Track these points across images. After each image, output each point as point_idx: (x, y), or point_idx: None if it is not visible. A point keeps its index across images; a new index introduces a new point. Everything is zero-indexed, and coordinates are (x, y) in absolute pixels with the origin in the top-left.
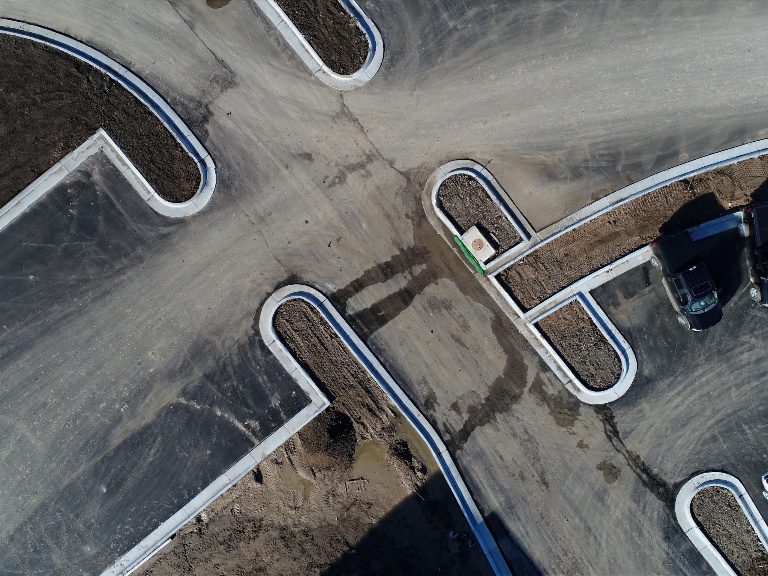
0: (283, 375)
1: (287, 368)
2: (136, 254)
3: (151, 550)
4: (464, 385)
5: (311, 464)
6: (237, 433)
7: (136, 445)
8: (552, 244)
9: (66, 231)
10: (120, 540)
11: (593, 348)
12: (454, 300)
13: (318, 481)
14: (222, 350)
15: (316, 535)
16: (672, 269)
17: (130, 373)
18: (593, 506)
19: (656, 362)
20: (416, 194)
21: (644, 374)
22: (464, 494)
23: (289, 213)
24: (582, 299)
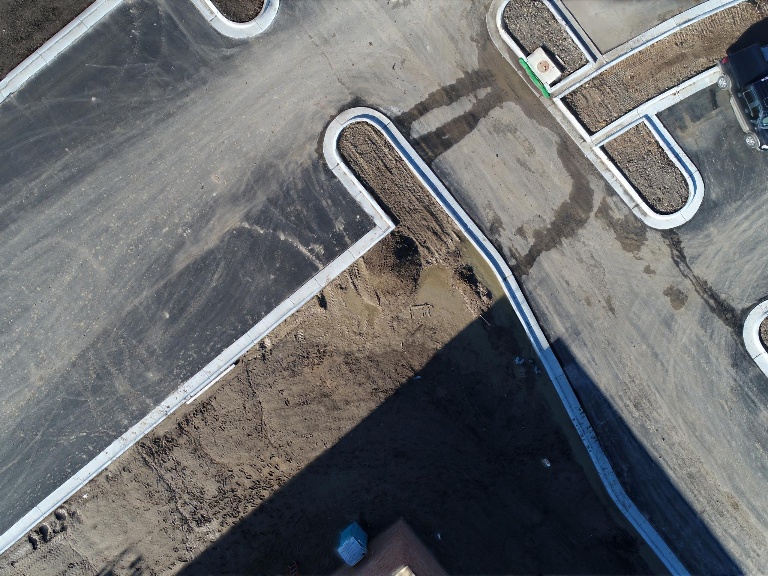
0: (347, 199)
1: (351, 191)
2: (199, 76)
3: (215, 375)
4: (529, 209)
5: (376, 288)
6: (301, 257)
7: (199, 270)
8: (618, 66)
9: (129, 52)
10: (183, 366)
11: (660, 171)
12: (519, 124)
13: (383, 306)
14: (285, 174)
15: (381, 361)
16: (743, 83)
17: (193, 197)
18: (660, 332)
19: (723, 186)
20: (481, 16)
21: (711, 198)
22: (530, 319)
23: (353, 35)
24: (649, 122)
